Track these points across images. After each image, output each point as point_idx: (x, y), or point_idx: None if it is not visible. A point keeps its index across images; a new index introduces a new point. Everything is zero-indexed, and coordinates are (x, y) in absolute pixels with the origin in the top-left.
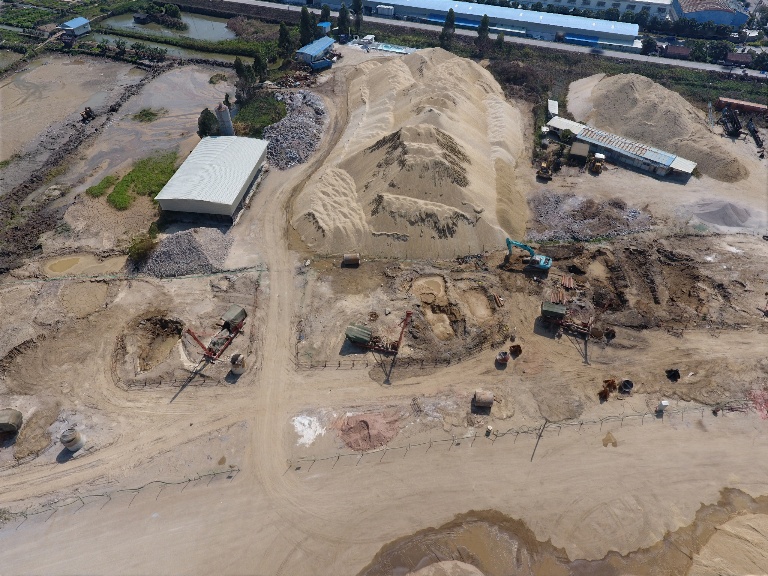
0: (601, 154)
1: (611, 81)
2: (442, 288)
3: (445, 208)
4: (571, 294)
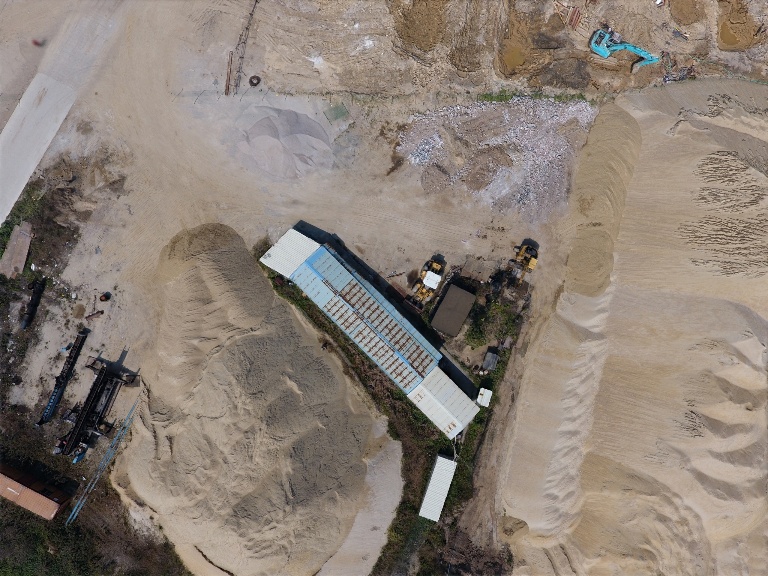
0: (429, 284)
1: (315, 539)
2: (720, 30)
3: (735, 121)
4: (575, 0)
